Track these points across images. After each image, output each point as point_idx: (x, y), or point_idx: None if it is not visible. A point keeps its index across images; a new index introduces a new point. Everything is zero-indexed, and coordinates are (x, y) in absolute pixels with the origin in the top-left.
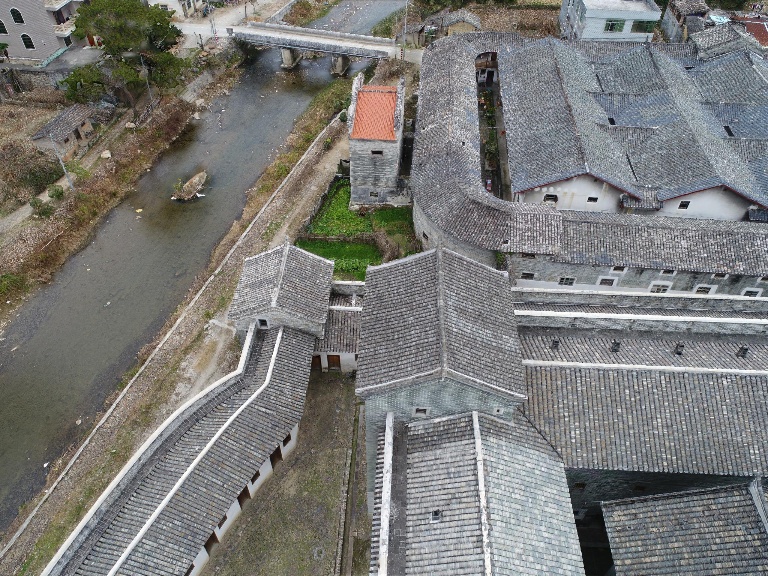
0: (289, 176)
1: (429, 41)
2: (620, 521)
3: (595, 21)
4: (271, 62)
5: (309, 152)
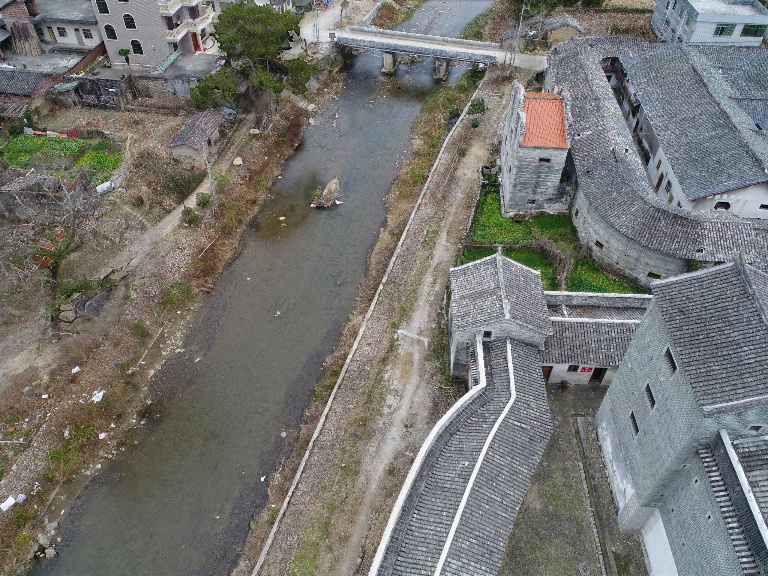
0: (428, 183)
1: (529, 45)
2: None
3: (705, 25)
4: (370, 67)
5: (441, 158)
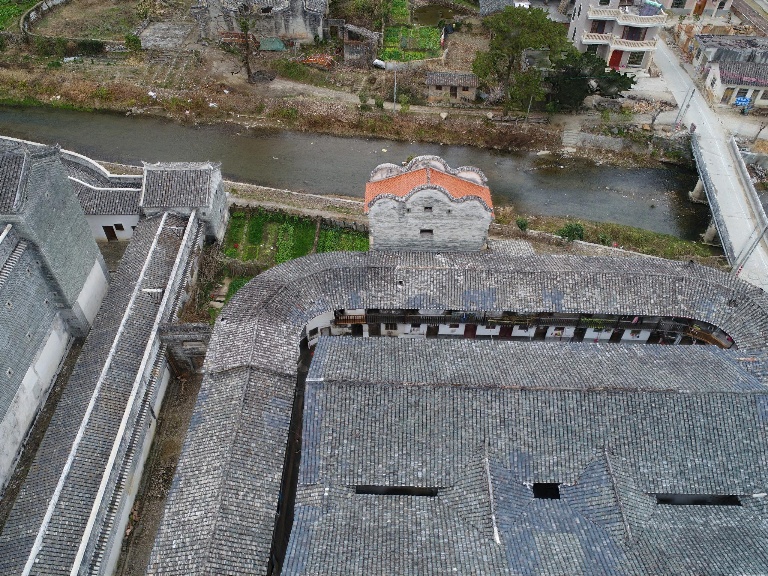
0: None
1: None
2: None
3: None
4: None
5: None
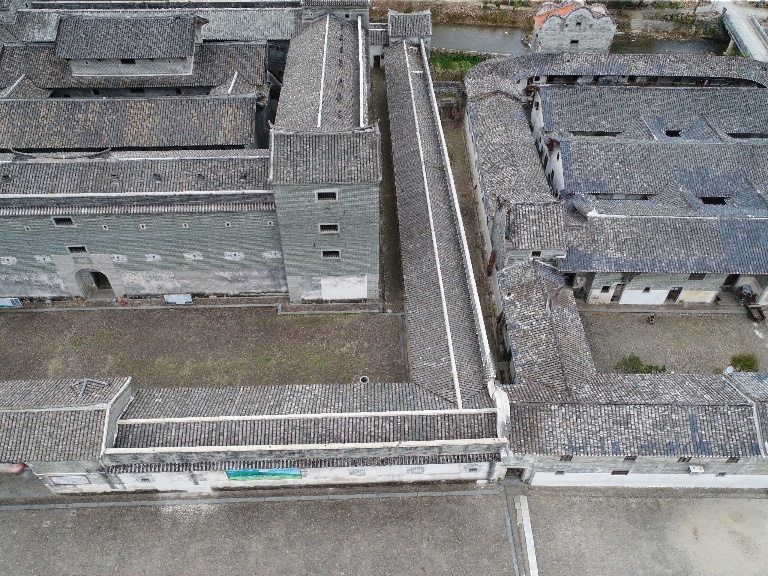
0: None
1: None
2: None
3: None
4: None
5: None
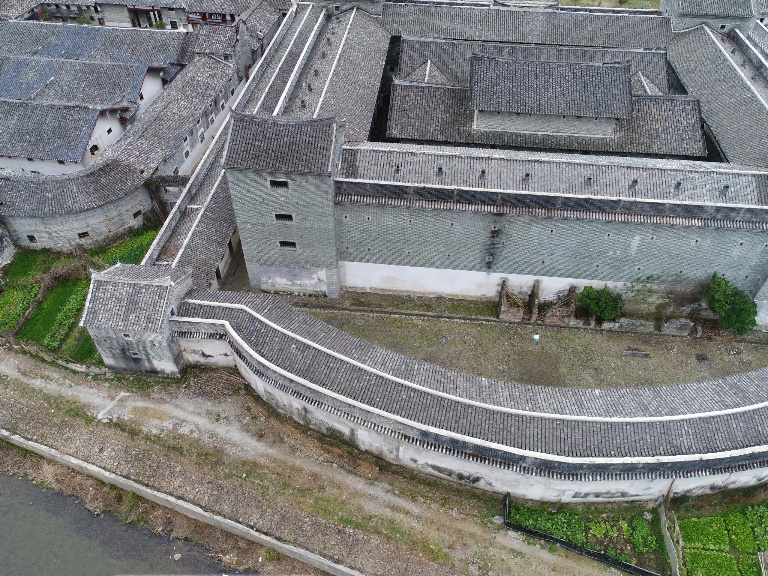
0: None
1: None
2: (397, 131)
3: None
4: None
5: None
